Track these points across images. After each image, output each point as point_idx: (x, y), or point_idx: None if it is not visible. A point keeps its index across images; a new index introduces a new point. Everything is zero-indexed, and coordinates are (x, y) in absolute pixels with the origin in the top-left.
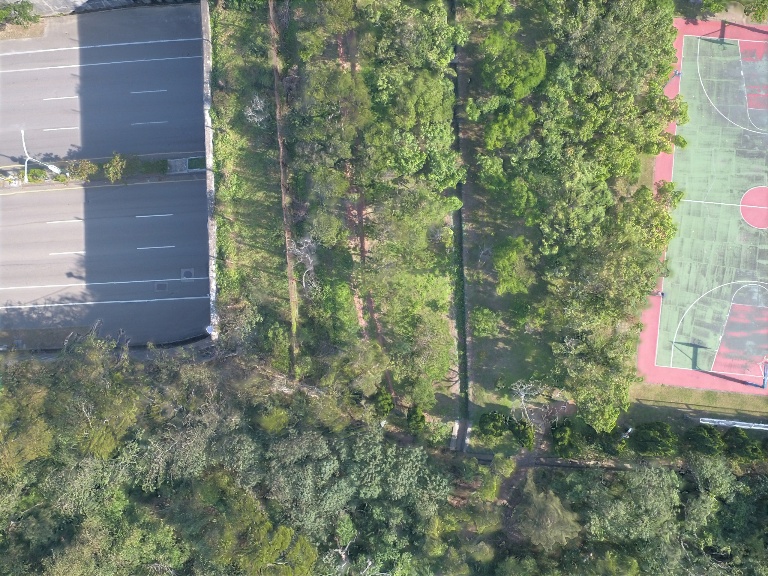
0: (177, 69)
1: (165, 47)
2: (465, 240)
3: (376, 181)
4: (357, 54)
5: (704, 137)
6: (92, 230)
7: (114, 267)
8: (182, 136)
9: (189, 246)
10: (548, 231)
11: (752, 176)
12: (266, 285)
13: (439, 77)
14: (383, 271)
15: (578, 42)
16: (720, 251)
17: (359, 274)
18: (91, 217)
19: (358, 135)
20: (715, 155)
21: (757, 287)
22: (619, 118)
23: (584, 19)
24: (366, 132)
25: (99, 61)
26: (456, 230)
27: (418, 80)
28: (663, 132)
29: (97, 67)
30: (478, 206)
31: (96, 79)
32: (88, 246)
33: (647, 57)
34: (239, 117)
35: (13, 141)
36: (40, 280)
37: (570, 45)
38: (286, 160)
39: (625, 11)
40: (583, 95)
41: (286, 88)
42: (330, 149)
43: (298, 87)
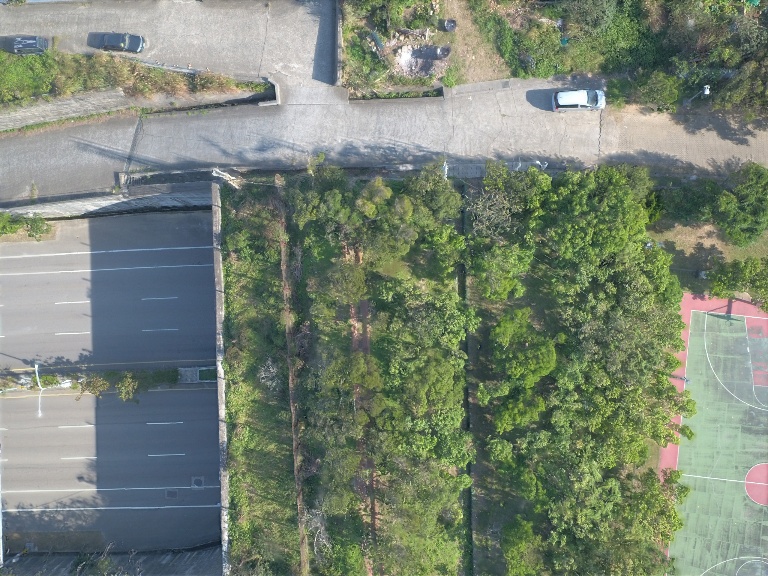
0: (188, 277)
1: (176, 254)
2: (474, 505)
3: (387, 460)
4: (368, 315)
5: (710, 413)
6: (103, 435)
7: (125, 473)
8: (193, 344)
9: (199, 454)
10: (556, 521)
11: (757, 453)
12: (277, 536)
13: (450, 356)
14: (394, 558)
15: (588, 337)
16: (725, 527)
17: (369, 535)
18: (102, 423)
19: (370, 420)
20: (721, 431)
21: (761, 563)
22: (627, 410)
23: (594, 312)
24: (378, 417)
25: (110, 266)
26: (465, 492)
27: (429, 366)
28: (670, 423)
29: (108, 272)
30: (487, 473)
31: (107, 284)
32: (99, 451)
33: (655, 353)
34: (251, 369)
35: (25, 344)
36: (52, 484)
37: (580, 339)
38: (298, 415)
39: (634, 307)
40: (592, 383)
41: (298, 347)
42: (342, 428)
43: (310, 344)
